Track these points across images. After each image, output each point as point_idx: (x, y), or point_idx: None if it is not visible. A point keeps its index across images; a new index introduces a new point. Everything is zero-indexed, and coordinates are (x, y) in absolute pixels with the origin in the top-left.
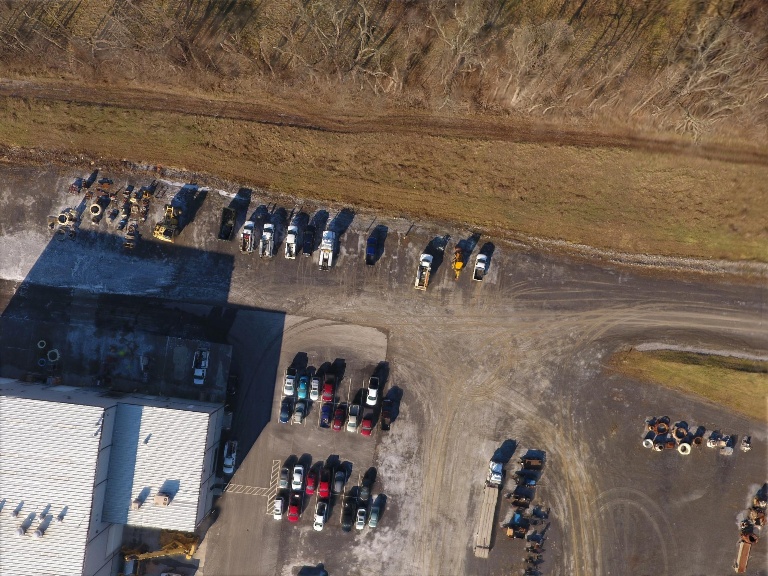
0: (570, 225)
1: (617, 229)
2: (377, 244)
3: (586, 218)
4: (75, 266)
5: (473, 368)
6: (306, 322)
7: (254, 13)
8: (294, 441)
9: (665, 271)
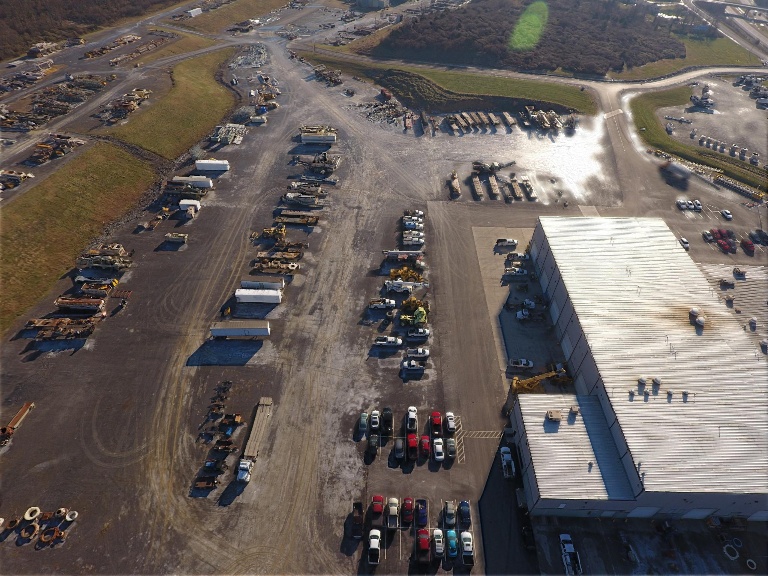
0: None
1: None
2: None
3: None
4: None
5: None
6: None
7: None
8: (449, 483)
9: None
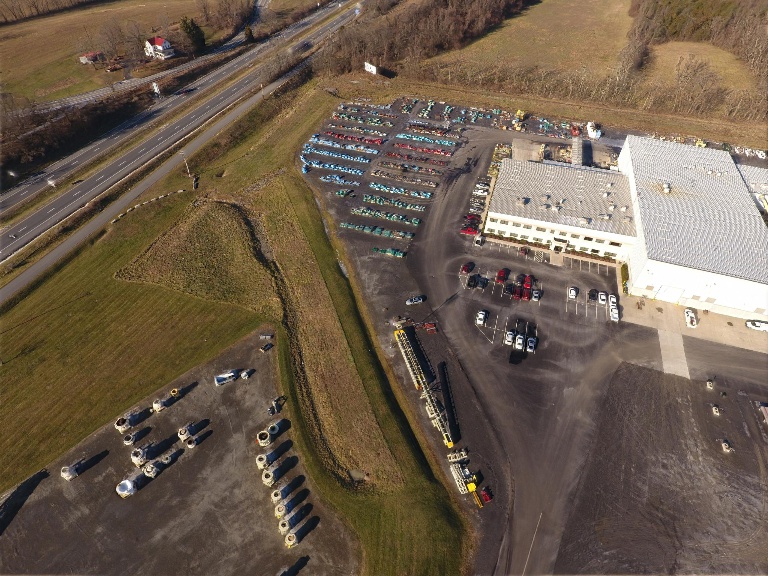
0: None
1: None
2: None
3: None
4: None
5: None
6: None
7: (712, 108)
8: None
9: None
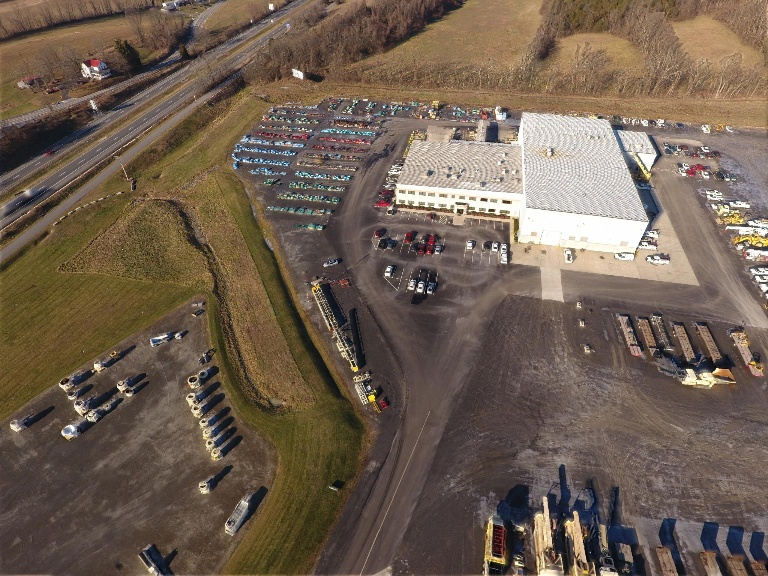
0: (760, 122)
1: None
2: None
3: (765, 120)
4: None
5: None
6: None
7: None
8: (677, 160)
9: None
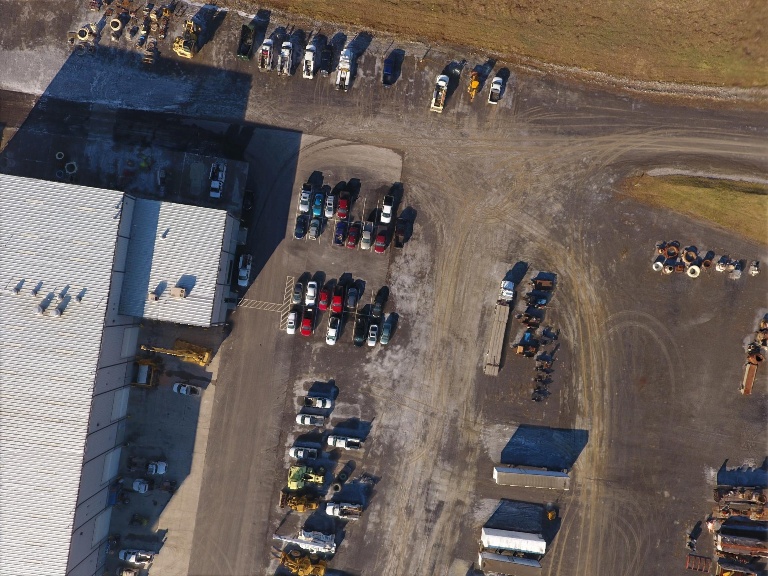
0: (585, 50)
1: (632, 54)
2: (394, 66)
3: (601, 42)
4: (94, 81)
5: (486, 191)
6: (322, 142)
7: None
8: (308, 258)
9: (678, 98)
